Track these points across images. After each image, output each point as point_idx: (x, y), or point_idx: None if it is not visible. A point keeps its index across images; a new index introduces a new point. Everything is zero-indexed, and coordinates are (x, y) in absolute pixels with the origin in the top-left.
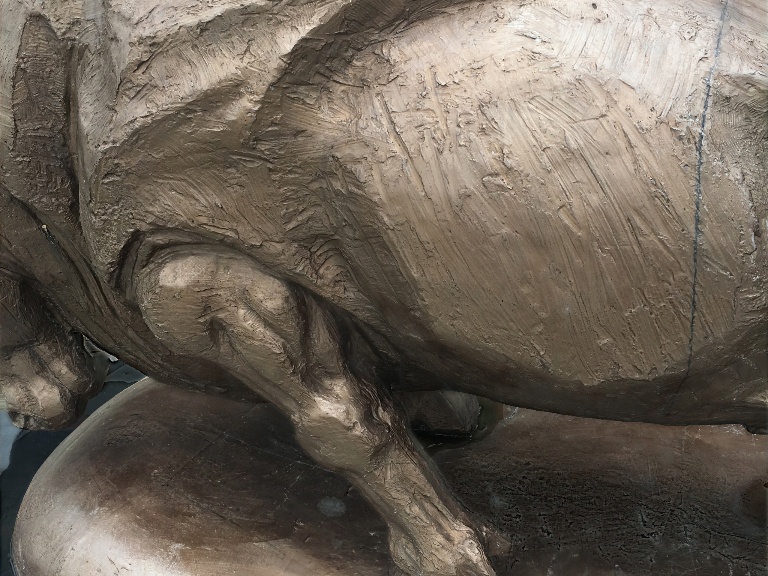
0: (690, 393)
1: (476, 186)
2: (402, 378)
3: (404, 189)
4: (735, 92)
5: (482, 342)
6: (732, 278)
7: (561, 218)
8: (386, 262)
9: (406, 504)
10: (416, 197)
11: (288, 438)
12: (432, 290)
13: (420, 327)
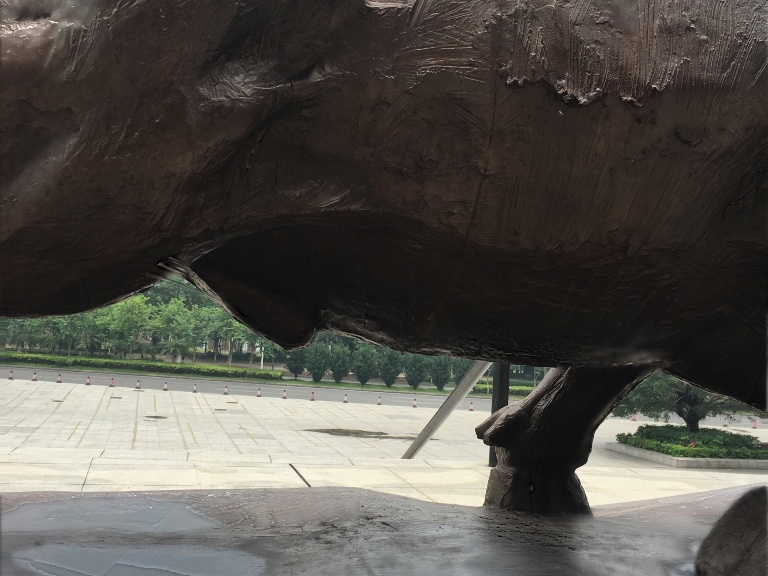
0: None
1: None
2: None
3: None
4: None
5: None
6: None
7: None
8: None
9: None
10: None
11: None
12: None
13: None
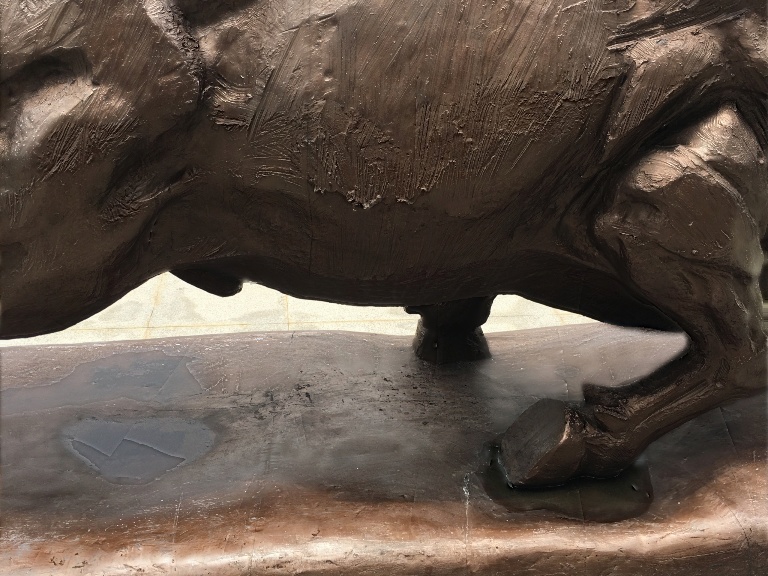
0: None
1: None
2: None
3: None
4: None
5: None
6: None
7: None
8: None
9: None
10: None
11: None
12: None
13: None
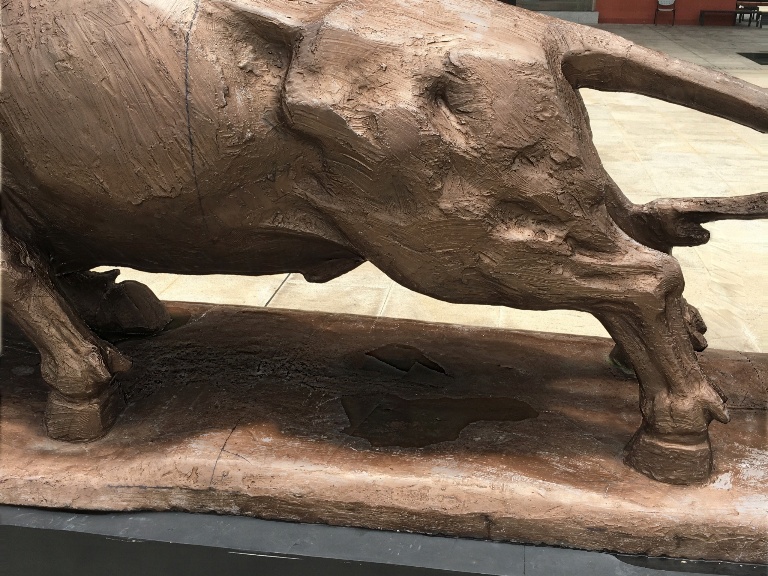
0: (214, 216)
1: (51, 69)
2: (56, 247)
3: (8, 74)
4: (215, 11)
5: (65, 178)
6: (213, 123)
7: (103, 86)
8: (4, 129)
9: (45, 326)
10: (16, 79)
11: (3, 334)
12: (30, 143)
13: (32, 176)
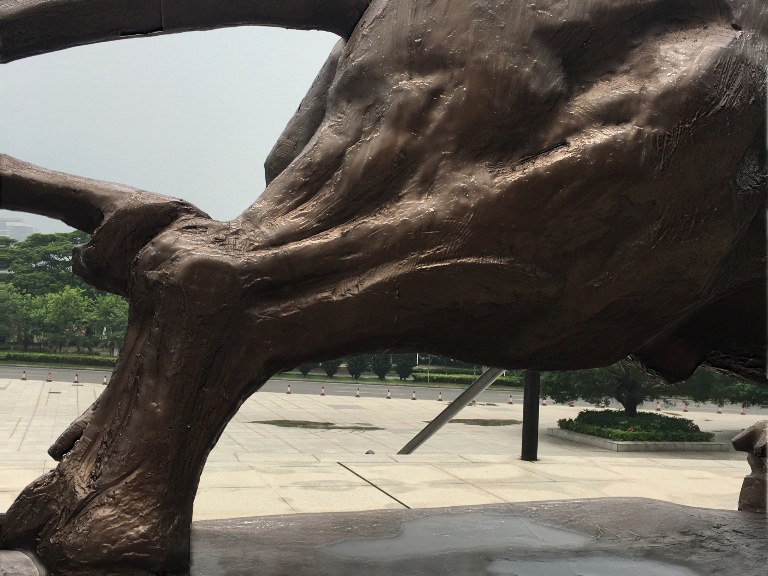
0: None
1: None
2: None
3: None
4: None
5: None
6: None
7: None
8: None
9: None
10: None
11: None
12: None
13: None
